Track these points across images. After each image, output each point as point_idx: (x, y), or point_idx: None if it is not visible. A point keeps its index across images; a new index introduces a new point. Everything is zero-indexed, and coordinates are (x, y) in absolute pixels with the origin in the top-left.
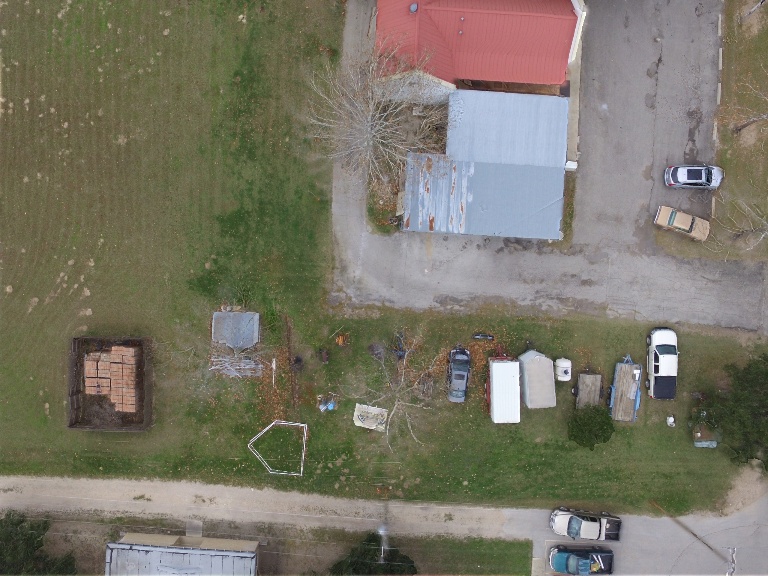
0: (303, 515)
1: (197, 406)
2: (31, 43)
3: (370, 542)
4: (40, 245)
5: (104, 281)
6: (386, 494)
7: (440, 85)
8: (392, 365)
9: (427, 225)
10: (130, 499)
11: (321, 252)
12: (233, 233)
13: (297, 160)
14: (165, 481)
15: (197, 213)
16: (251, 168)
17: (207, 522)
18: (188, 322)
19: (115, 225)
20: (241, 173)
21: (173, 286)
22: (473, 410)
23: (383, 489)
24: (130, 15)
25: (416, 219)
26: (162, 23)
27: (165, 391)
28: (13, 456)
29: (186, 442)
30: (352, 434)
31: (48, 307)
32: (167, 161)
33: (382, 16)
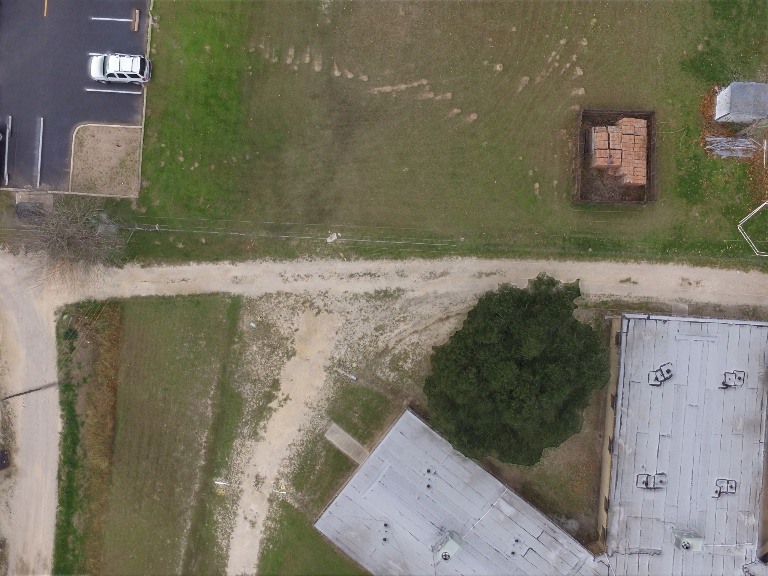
0: None
1: (688, 187)
2: None
3: None
4: (531, 24)
5: (597, 61)
6: None
7: None
8: None
9: None
10: (616, 282)
11: None
12: (726, 16)
13: None
14: (652, 263)
15: None
16: None
17: (692, 305)
18: (680, 103)
19: (608, 5)
20: None
21: (666, 67)
22: None
23: None
24: None
25: None
26: None
27: (657, 171)
28: (499, 238)
29: (676, 223)
30: None
31: (539, 86)
32: None
33: None
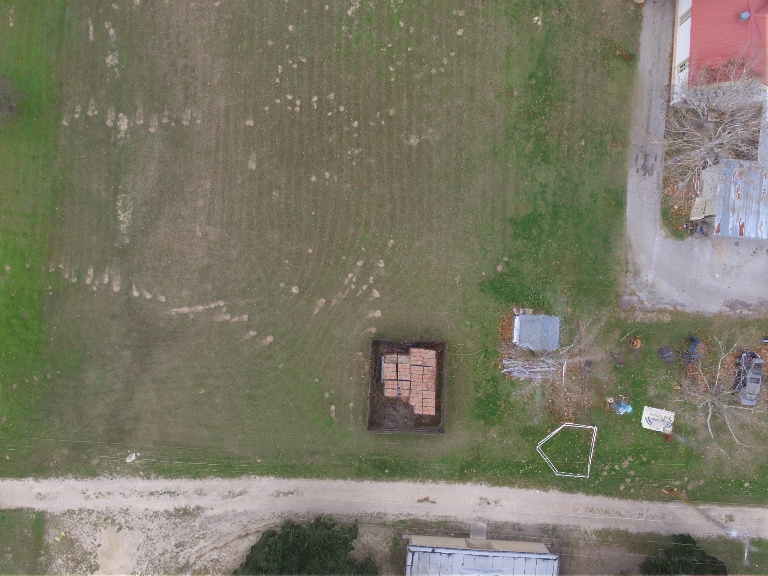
0: (587, 517)
1: (486, 408)
2: (320, 40)
3: (686, 543)
4: (327, 245)
5: (394, 282)
6: (671, 495)
7: (763, 92)
8: (680, 368)
9: (737, 230)
10: (414, 502)
11: (615, 256)
12: (526, 236)
13: (593, 163)
14: (450, 483)
15: (489, 215)
16: (545, 171)
17: (491, 524)
18: (479, 324)
19: (406, 226)
20: (535, 176)
21: (464, 288)
22: (757, 413)
23: (668, 491)
24: (423, 14)
25: (726, 224)
26: (456, 23)
27: (454, 393)
28: (296, 459)
29: (474, 444)
30: (640, 436)
31: (335, 308)
32: (459, 162)
33: (701, 22)
